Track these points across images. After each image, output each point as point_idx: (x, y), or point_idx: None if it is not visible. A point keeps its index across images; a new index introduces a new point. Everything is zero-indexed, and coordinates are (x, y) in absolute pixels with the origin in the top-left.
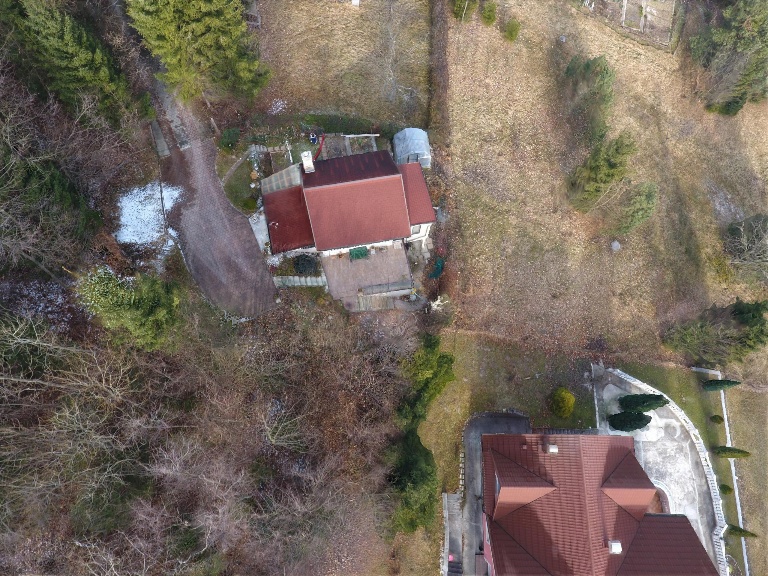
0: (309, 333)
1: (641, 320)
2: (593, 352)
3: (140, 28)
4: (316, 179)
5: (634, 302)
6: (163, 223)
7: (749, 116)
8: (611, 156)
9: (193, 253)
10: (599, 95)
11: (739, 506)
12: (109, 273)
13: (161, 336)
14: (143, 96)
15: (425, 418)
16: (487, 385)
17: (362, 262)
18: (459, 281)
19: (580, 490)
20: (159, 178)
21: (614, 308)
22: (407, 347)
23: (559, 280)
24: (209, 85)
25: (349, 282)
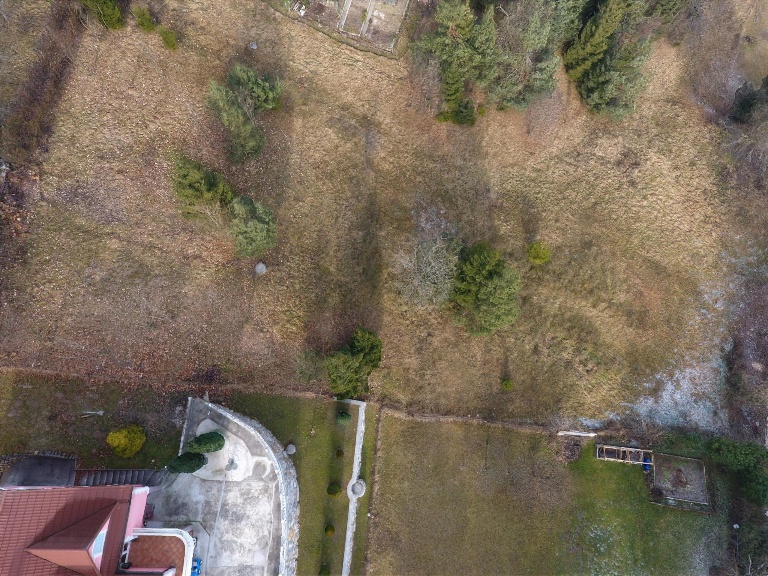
0: None
1: (282, 347)
2: (196, 384)
3: None
4: None
5: (277, 328)
6: None
7: (495, 125)
8: None
9: None
10: None
11: (347, 547)
12: None
13: None
14: None
15: None
16: (17, 426)
17: None
18: (5, 313)
19: None
20: None
21: (245, 335)
22: None
23: (165, 307)
24: None
25: None
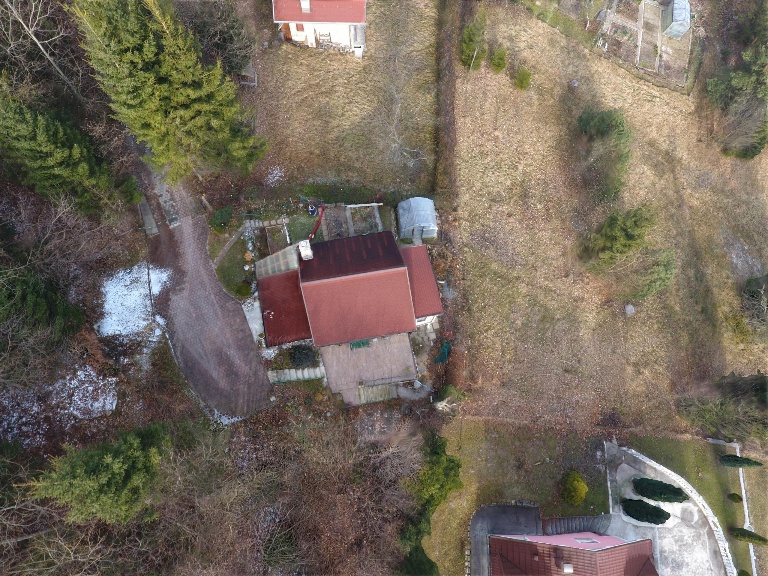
0: (306, 434)
1: (656, 388)
2: (606, 428)
3: (122, 119)
4: (314, 270)
5: (648, 369)
6: (150, 310)
7: (766, 158)
8: (629, 227)
9: (182, 344)
10: (615, 153)
11: None
12: (90, 375)
13: (137, 504)
14: (128, 180)
15: (430, 534)
16: (495, 475)
17: (363, 350)
18: (466, 361)
19: None
20: (146, 259)
21: (628, 377)
22: (411, 464)
23: (571, 351)
24: (200, 163)
25: (349, 373)
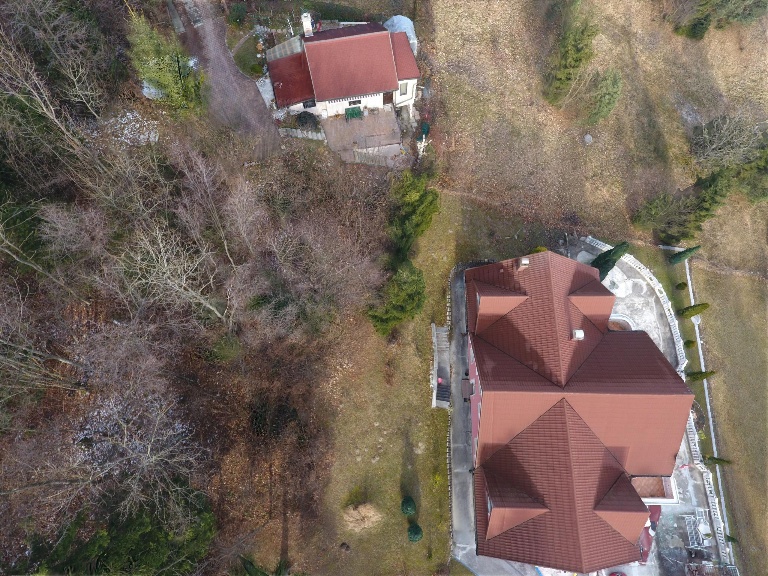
0: (311, 174)
1: (612, 204)
2: (567, 224)
3: None
4: (315, 38)
5: (606, 188)
6: (180, 87)
7: (715, 41)
8: (578, 40)
9: (208, 111)
10: None
11: (702, 360)
12: (136, 116)
13: (191, 102)
14: None
15: (413, 237)
16: (470, 238)
17: (356, 122)
18: (444, 151)
19: (549, 294)
20: (176, 50)
21: (587, 191)
22: (396, 168)
23: (536, 161)
24: None
25: (345, 138)
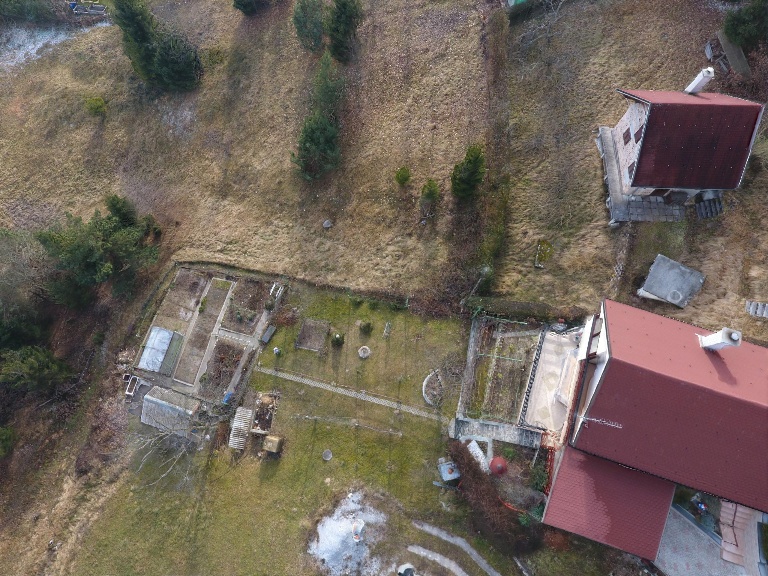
0: None
1: None
2: None
3: None
4: None
5: None
6: None
7: None
8: None
9: None
10: None
11: None
12: None
13: None
14: None
15: None
16: None
17: None
18: None
19: None
20: None
21: None
22: None
23: None
24: None
25: None
